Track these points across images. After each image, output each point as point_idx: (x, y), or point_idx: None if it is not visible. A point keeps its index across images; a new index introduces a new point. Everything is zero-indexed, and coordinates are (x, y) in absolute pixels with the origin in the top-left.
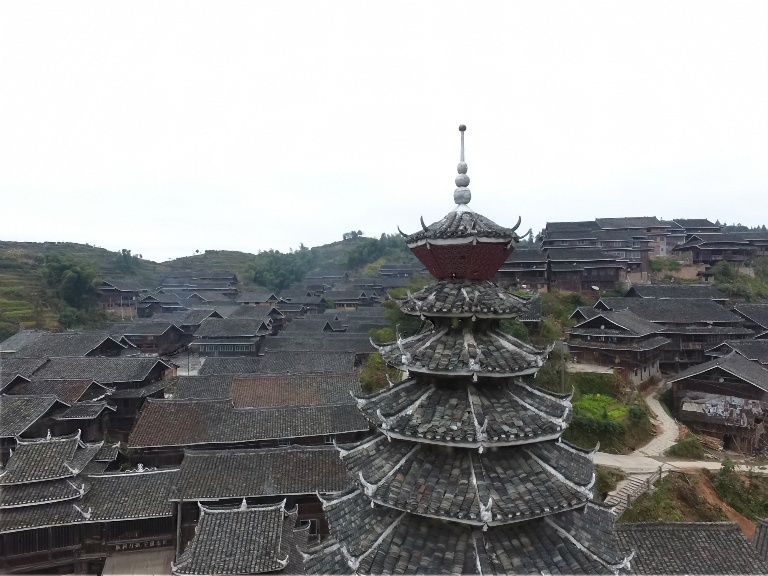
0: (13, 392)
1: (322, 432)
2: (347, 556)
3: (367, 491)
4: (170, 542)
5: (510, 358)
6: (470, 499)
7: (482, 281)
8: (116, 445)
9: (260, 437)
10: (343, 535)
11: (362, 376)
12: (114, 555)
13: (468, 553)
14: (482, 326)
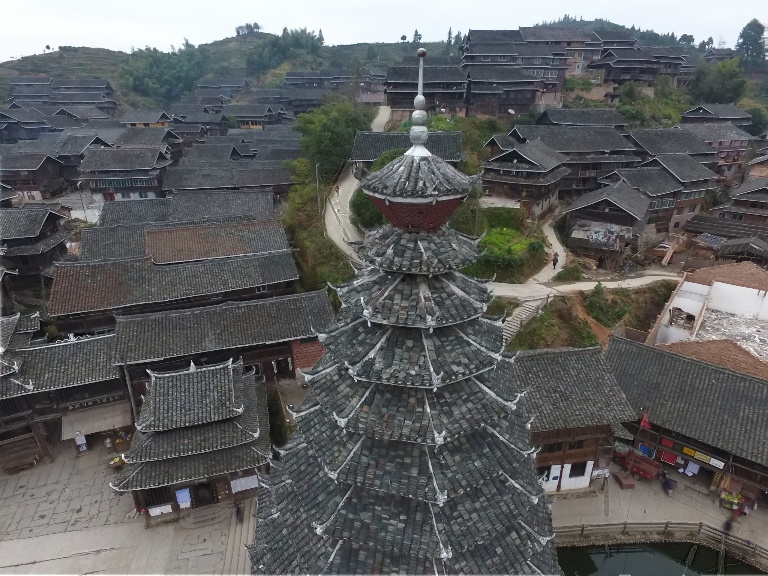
0: None
1: (253, 284)
2: (328, 472)
3: (340, 424)
4: (122, 397)
5: (460, 305)
6: (426, 426)
7: (436, 229)
8: (35, 315)
9: (190, 294)
10: (318, 446)
11: (283, 218)
12: (69, 414)
13: (422, 458)
14: None
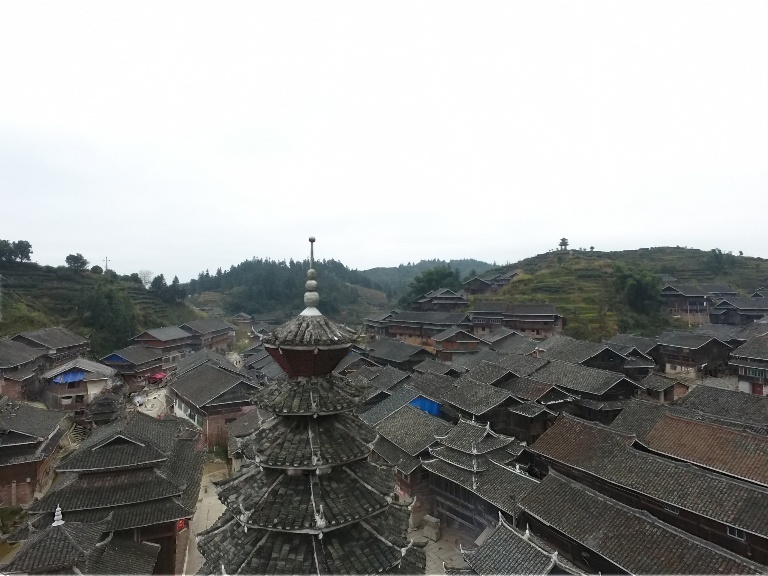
0: (508, 383)
1: (715, 516)
2: None
3: None
4: None
5: None
6: None
7: (294, 377)
8: (523, 444)
9: (637, 488)
10: None
11: None
12: (491, 527)
13: None
14: (292, 416)
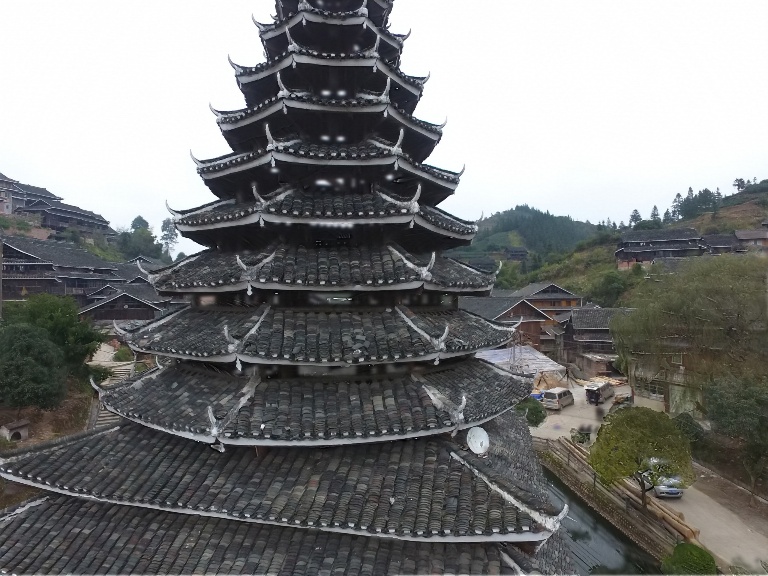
0: None
1: None
2: None
3: None
4: None
5: None
6: None
7: None
8: None
9: None
10: None
11: None
12: None
13: None
14: None
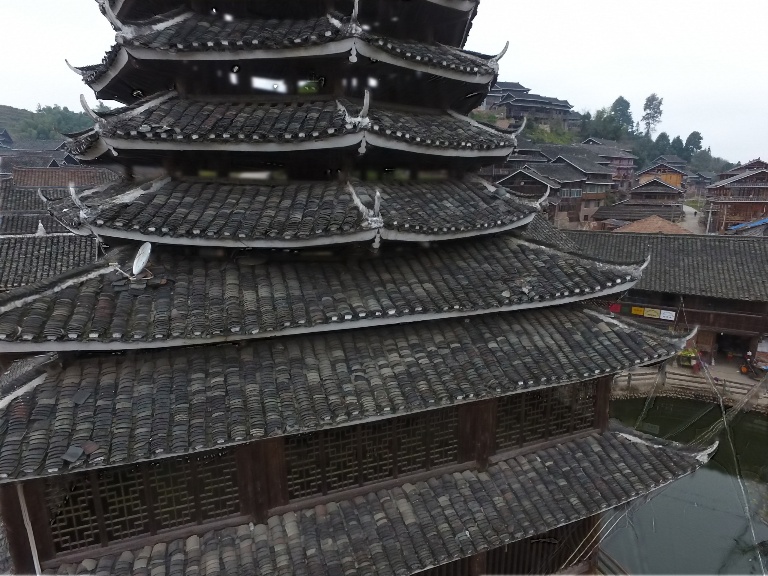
0: None
1: None
2: None
3: None
4: None
5: None
6: None
7: None
8: None
9: None
10: None
11: None
12: None
13: None
14: None
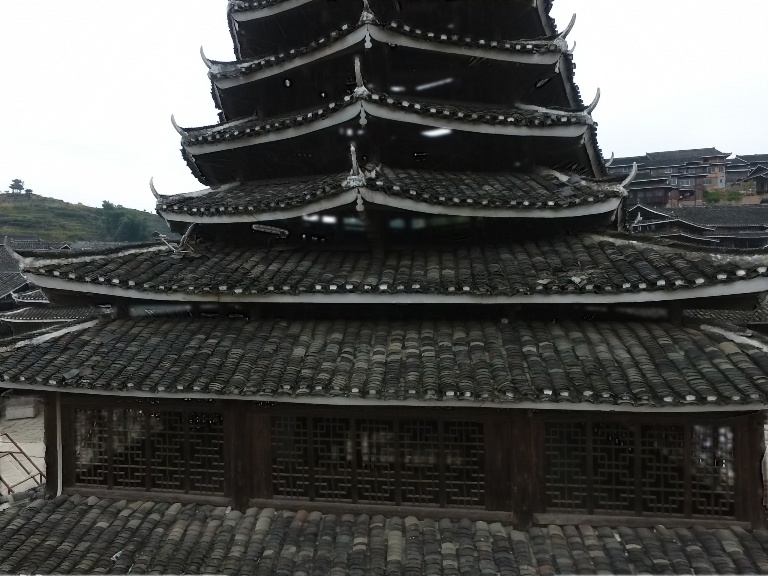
0: None
1: None
2: None
3: None
4: None
5: None
6: None
7: None
8: None
9: None
10: None
11: None
12: None
13: None
14: None
